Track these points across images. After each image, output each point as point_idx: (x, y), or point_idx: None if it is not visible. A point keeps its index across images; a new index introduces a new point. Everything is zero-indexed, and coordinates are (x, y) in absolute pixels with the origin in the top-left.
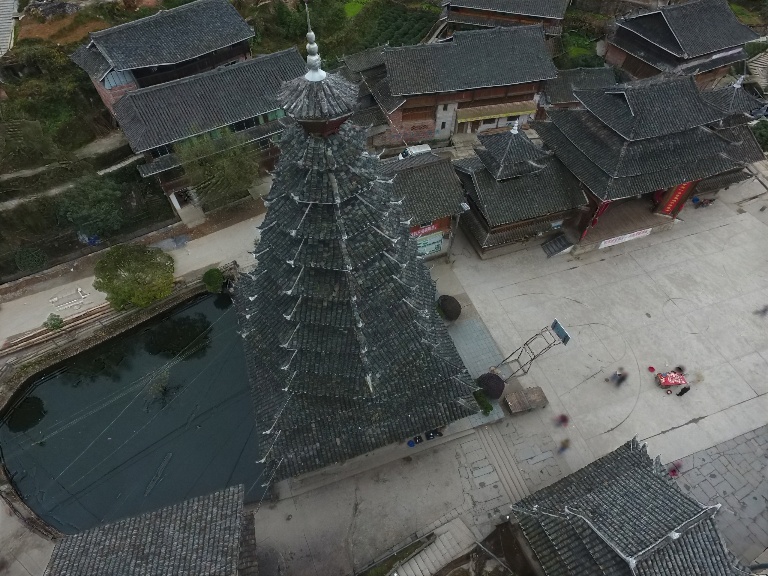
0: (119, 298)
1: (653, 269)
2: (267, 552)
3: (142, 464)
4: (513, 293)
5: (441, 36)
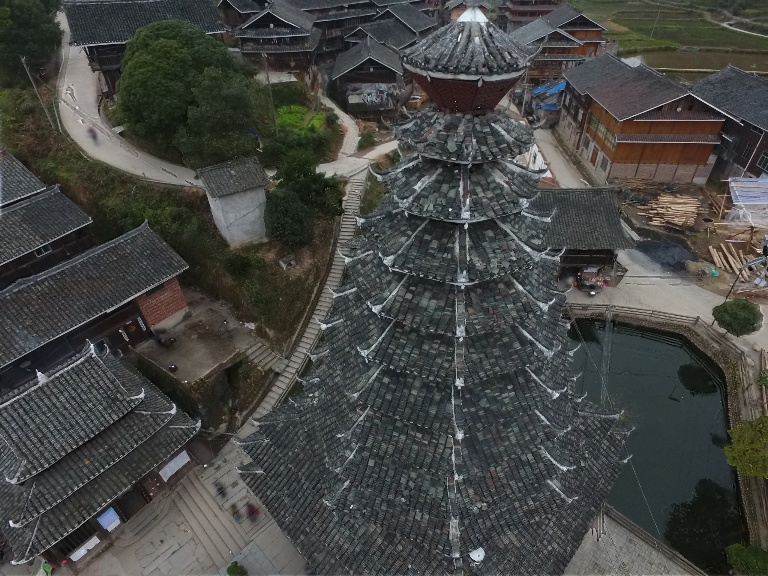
0: None
1: None
2: None
3: None
4: None
5: None
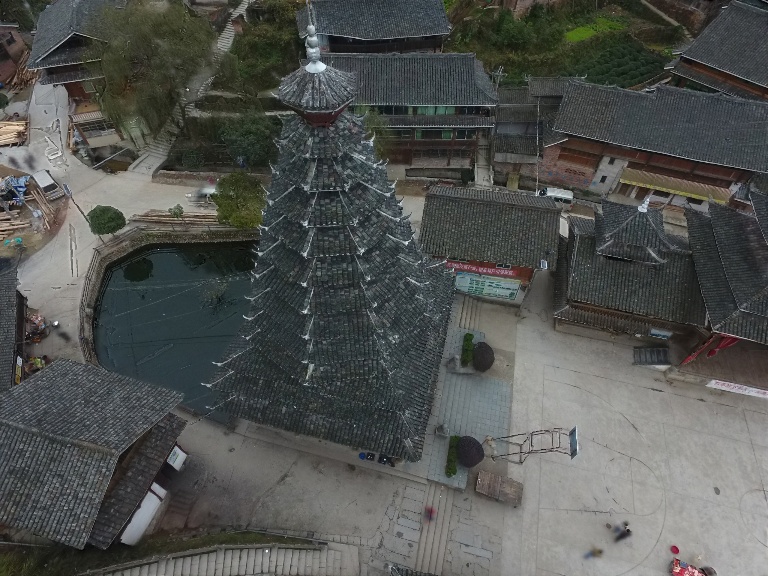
0: (223, 213)
1: (765, 444)
2: (197, 464)
3: (183, 348)
4: (565, 379)
5: None
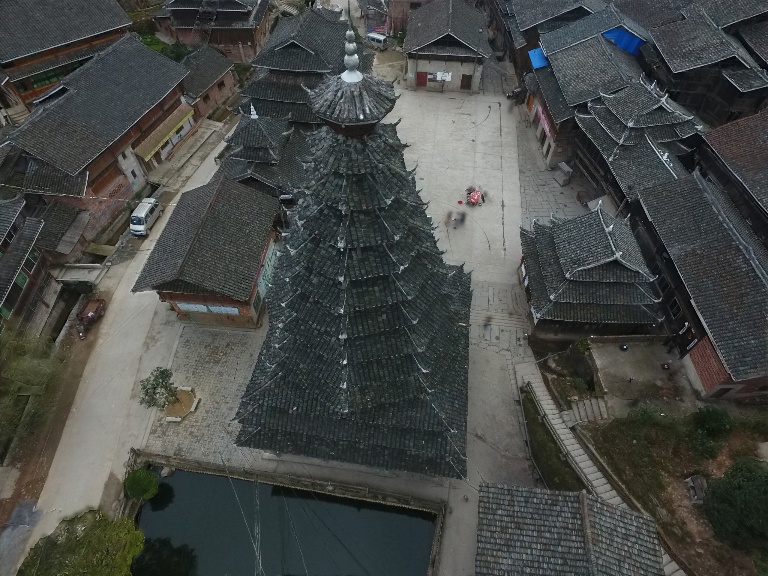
0: None
1: None
2: None
3: None
4: None
5: (2, 105)
